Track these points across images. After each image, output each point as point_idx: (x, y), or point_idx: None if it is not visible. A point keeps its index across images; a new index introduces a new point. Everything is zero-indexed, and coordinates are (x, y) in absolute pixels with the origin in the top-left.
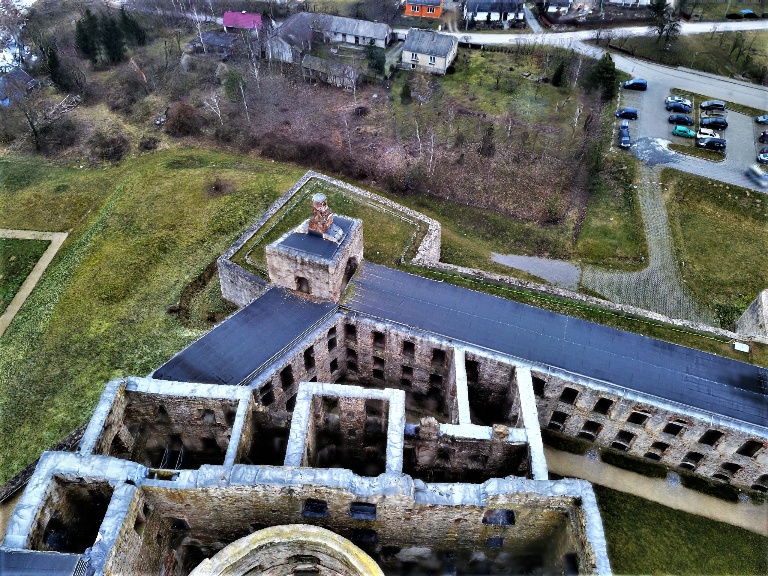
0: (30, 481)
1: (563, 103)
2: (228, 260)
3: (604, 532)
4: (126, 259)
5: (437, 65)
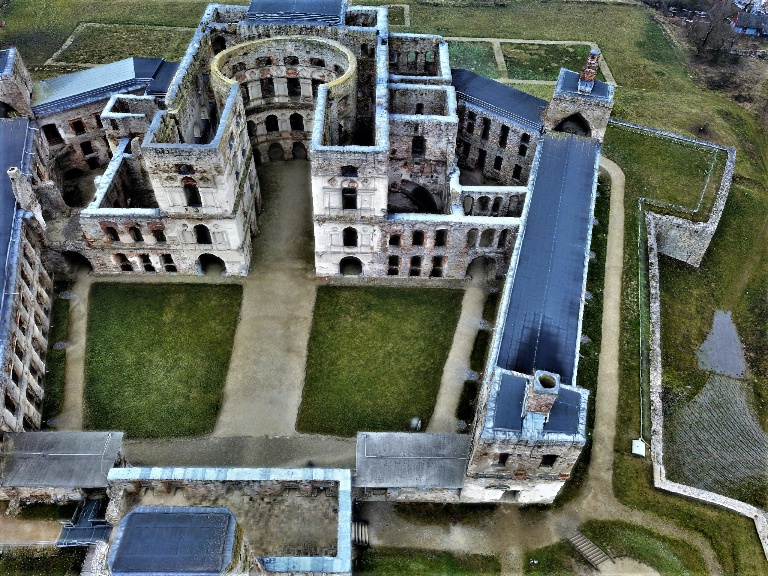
0: None
1: None
2: None
3: (418, 319)
4: None
5: None
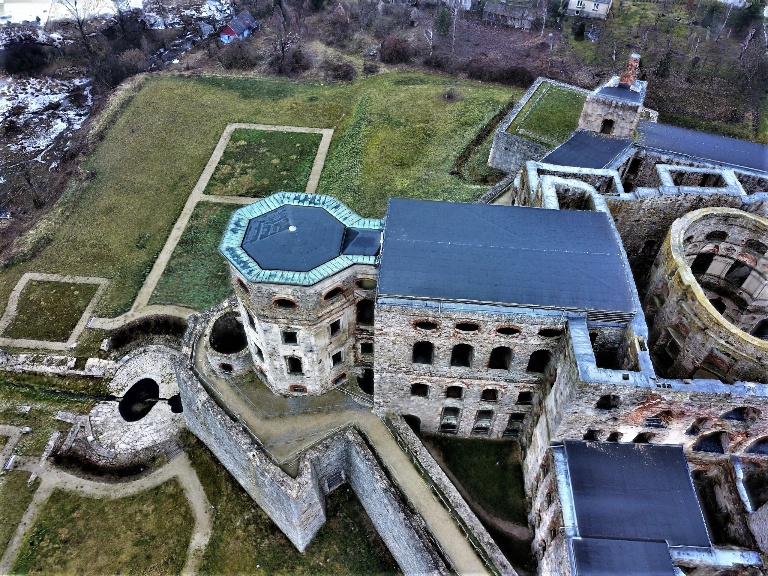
0: (543, 186)
1: (715, 40)
2: (505, 131)
3: None
4: (402, 140)
5: (600, 11)
